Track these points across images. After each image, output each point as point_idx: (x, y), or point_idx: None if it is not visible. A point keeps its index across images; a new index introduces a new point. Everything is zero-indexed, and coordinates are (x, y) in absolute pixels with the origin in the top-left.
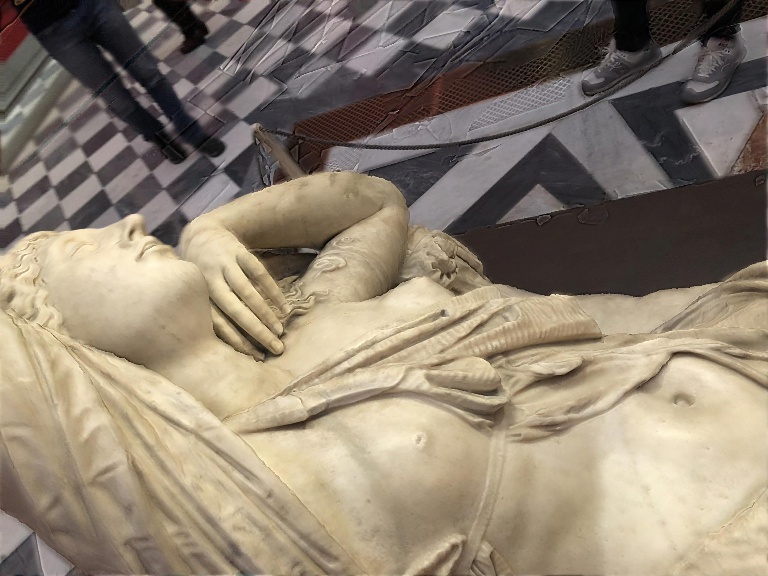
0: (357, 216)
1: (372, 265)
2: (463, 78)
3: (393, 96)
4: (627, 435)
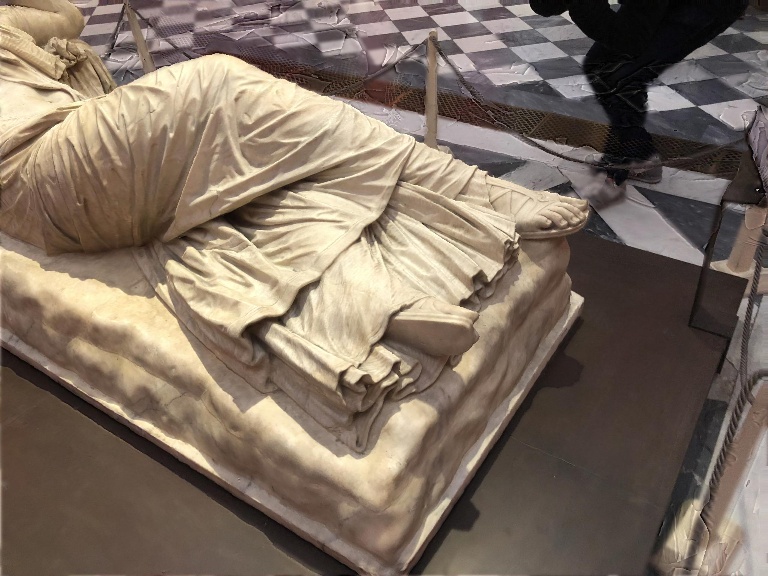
0: (37, 5)
1: (18, 21)
2: (258, 47)
3: (220, 37)
4: (8, 91)
